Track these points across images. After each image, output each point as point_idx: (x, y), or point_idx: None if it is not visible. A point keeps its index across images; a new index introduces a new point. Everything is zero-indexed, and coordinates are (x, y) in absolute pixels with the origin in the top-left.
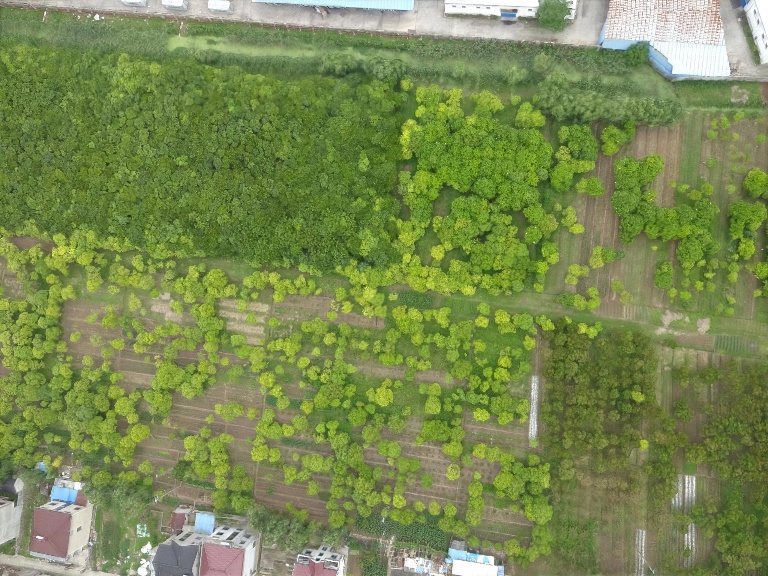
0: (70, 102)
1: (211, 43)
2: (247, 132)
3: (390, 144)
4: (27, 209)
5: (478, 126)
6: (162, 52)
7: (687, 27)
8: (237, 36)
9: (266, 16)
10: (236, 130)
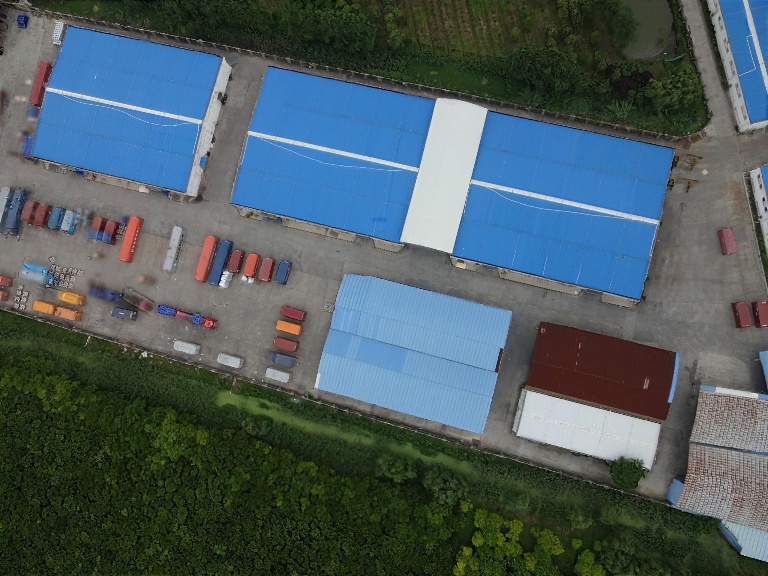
0: (106, 456)
1: (263, 407)
2: (294, 537)
3: (443, 575)
4: (45, 569)
5: (537, 575)
6: (211, 411)
7: (762, 517)
8: (293, 411)
9: (325, 392)
10: (282, 530)
